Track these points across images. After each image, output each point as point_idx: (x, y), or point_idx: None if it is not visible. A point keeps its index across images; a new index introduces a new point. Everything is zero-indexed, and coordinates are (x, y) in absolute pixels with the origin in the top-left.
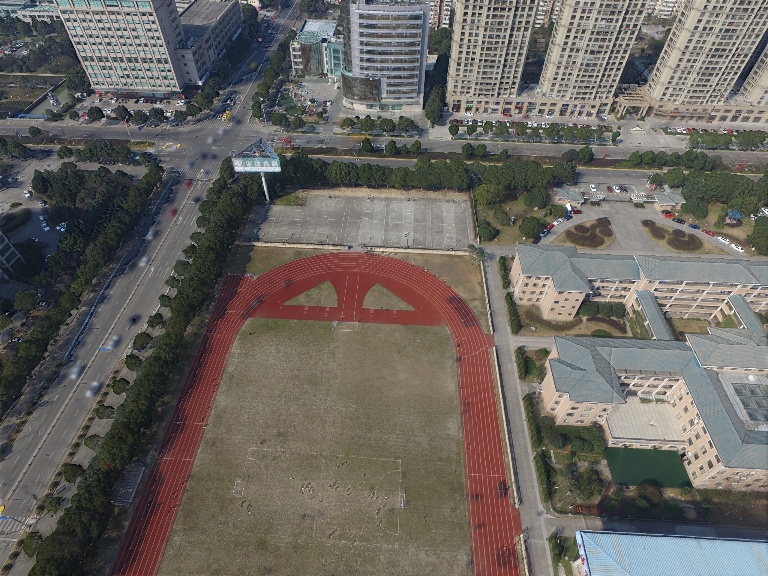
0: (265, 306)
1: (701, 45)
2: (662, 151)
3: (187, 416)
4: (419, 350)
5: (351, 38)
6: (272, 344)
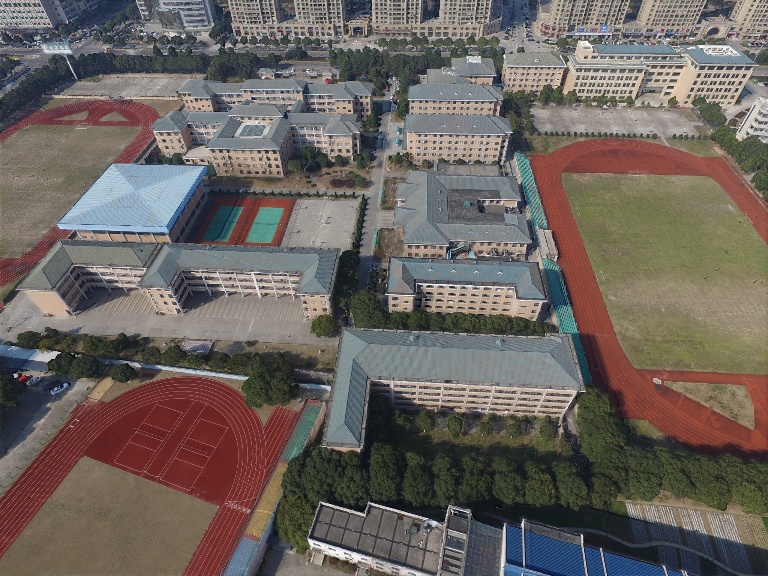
0: (42, 120)
1: None
2: None
3: None
4: (116, 135)
5: None
6: (36, 133)
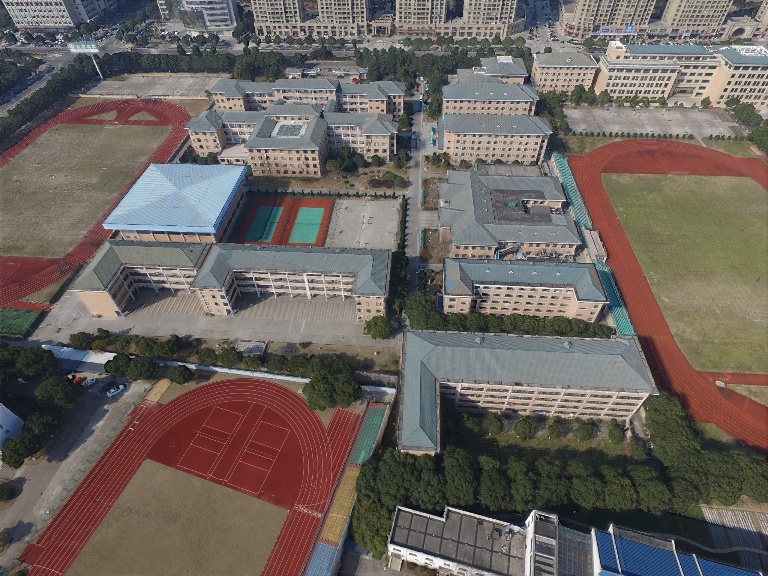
0: (72, 120)
1: None
2: (374, 48)
3: (4, 156)
4: (148, 134)
5: None
6: (66, 133)
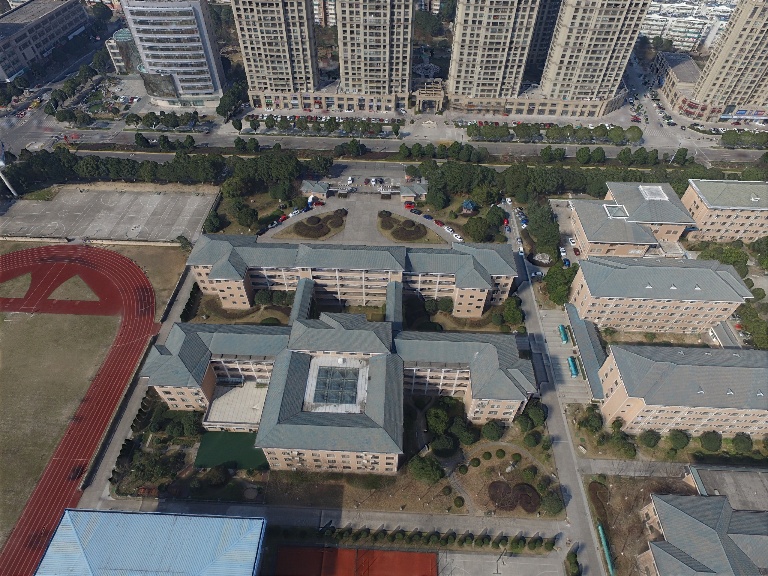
0: None
1: (476, 38)
2: None
3: None
4: (79, 339)
5: (132, 34)
6: None
